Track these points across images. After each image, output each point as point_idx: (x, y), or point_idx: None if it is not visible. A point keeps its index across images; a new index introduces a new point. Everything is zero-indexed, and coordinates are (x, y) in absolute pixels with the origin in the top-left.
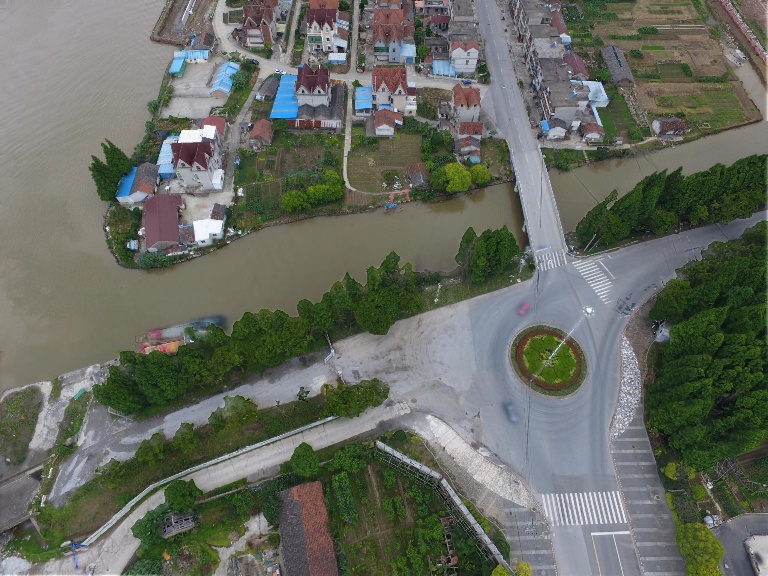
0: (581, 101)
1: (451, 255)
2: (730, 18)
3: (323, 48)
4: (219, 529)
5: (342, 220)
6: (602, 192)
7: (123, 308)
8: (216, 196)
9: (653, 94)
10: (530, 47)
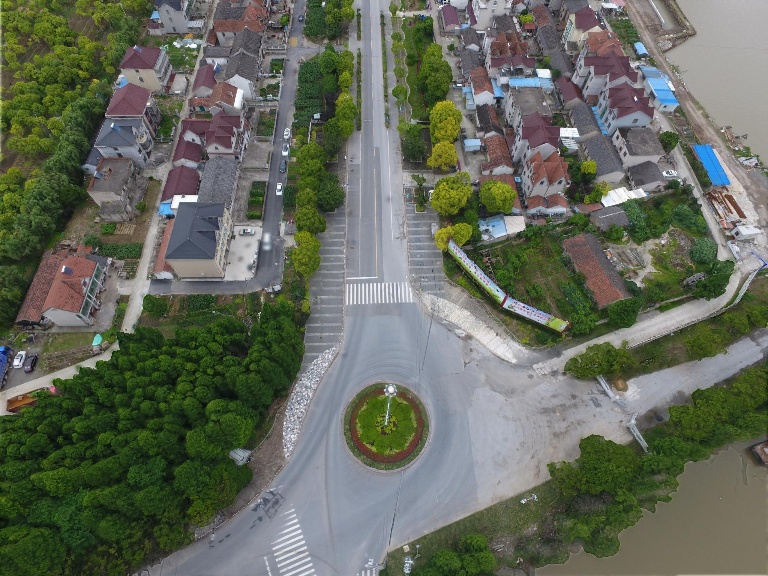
0: None
1: None
2: None
3: None
4: None
5: None
6: None
7: None
8: None
9: None
10: None
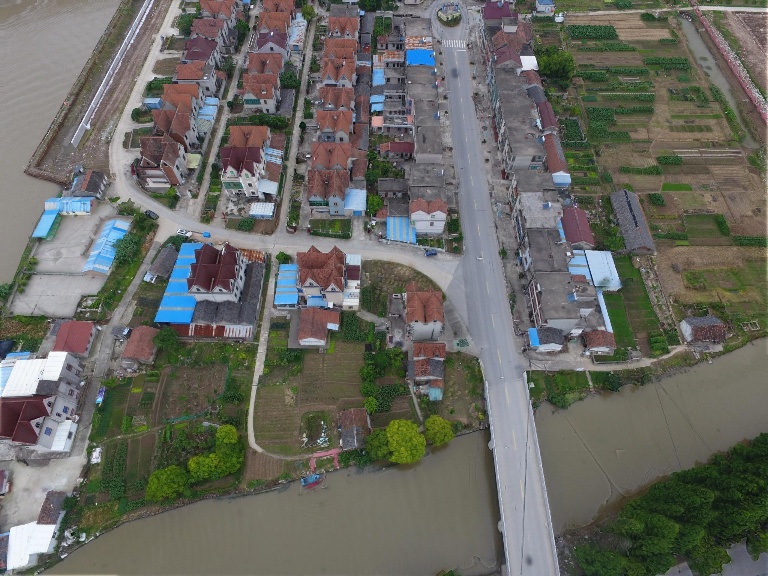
0: (584, 308)
1: (399, 536)
2: None
3: (245, 193)
4: None
5: (238, 506)
6: (612, 431)
7: None
8: (59, 464)
9: (680, 269)
10: (516, 200)
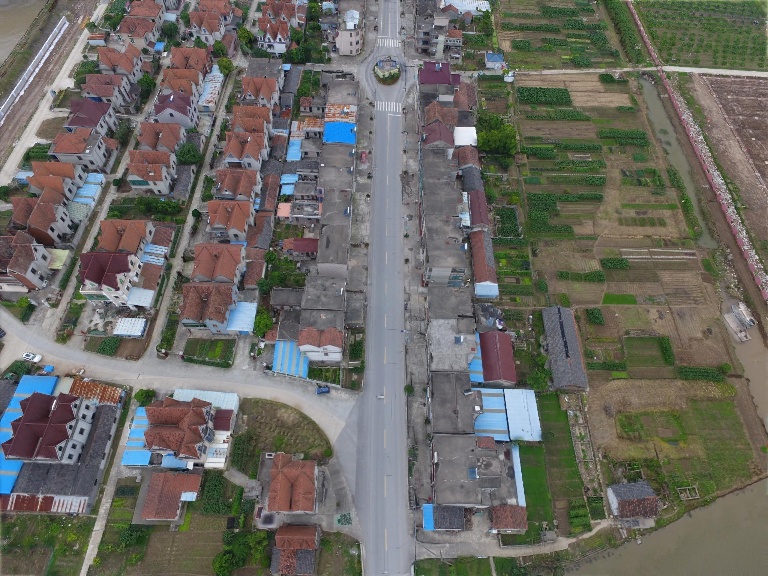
0: (487, 488)
1: None
2: (732, 237)
3: (114, 303)
4: None
5: None
6: None
7: None
8: None
9: (613, 413)
10: (428, 325)
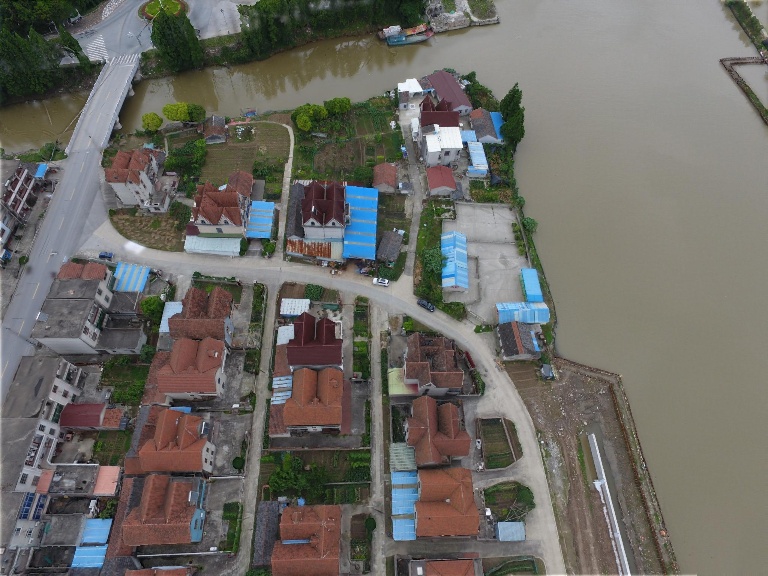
0: None
1: None
2: None
3: None
4: None
5: None
6: None
7: (454, 56)
8: None
9: None
10: None
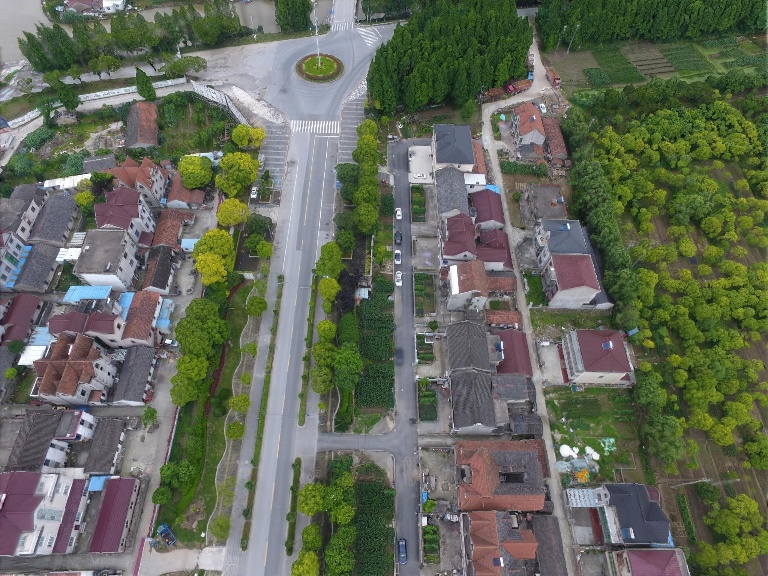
0: None
1: None
2: None
3: None
4: (92, 126)
5: None
6: None
7: None
8: None
9: None
10: None
